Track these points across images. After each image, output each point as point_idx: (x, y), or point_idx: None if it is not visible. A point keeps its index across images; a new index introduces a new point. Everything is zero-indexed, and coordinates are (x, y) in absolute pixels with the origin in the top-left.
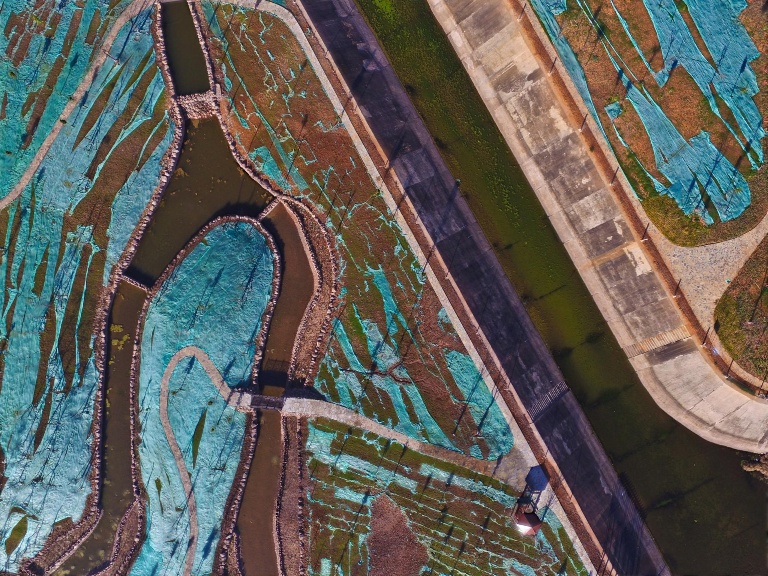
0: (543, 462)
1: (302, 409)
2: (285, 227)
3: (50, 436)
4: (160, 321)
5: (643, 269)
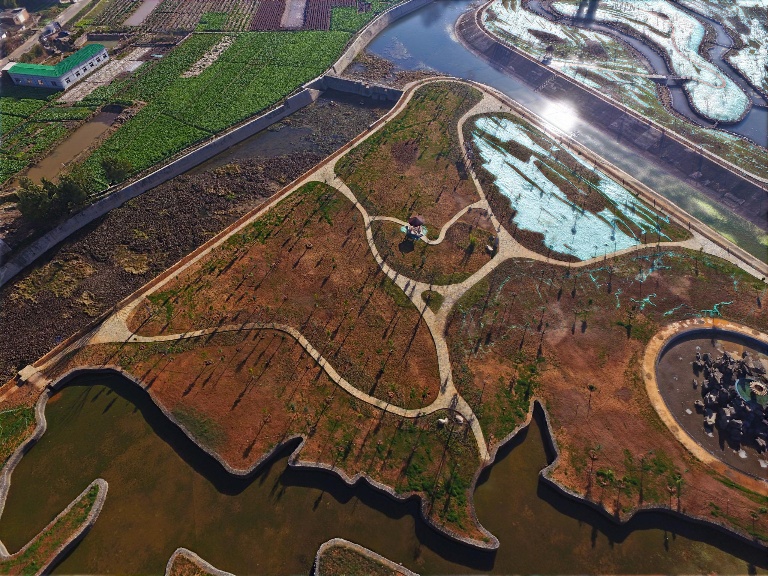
0: None
1: (657, 76)
2: None
3: (762, 68)
4: (740, 95)
5: (519, 108)
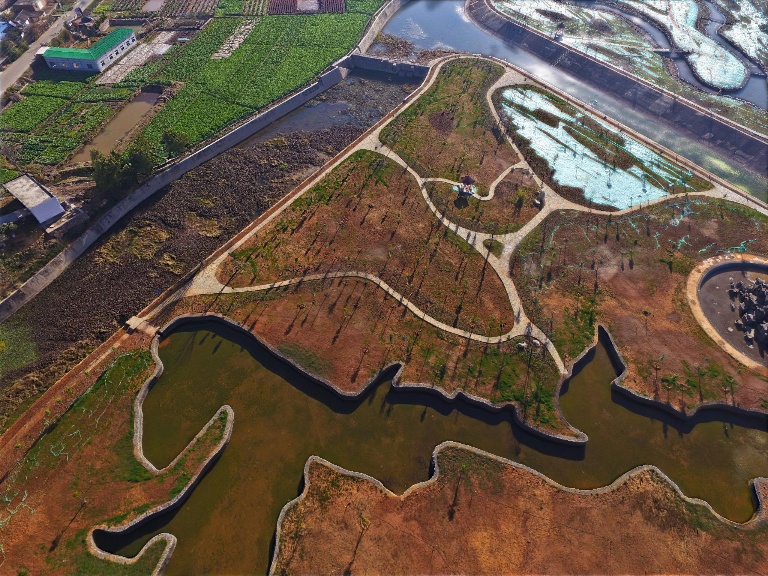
0: (558, 42)
1: None
2: (707, 90)
3: None
4: (739, 65)
5: None
